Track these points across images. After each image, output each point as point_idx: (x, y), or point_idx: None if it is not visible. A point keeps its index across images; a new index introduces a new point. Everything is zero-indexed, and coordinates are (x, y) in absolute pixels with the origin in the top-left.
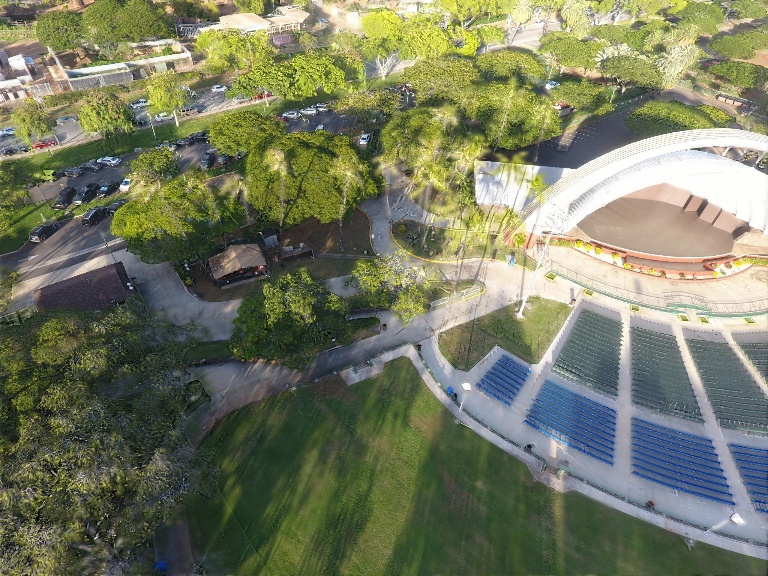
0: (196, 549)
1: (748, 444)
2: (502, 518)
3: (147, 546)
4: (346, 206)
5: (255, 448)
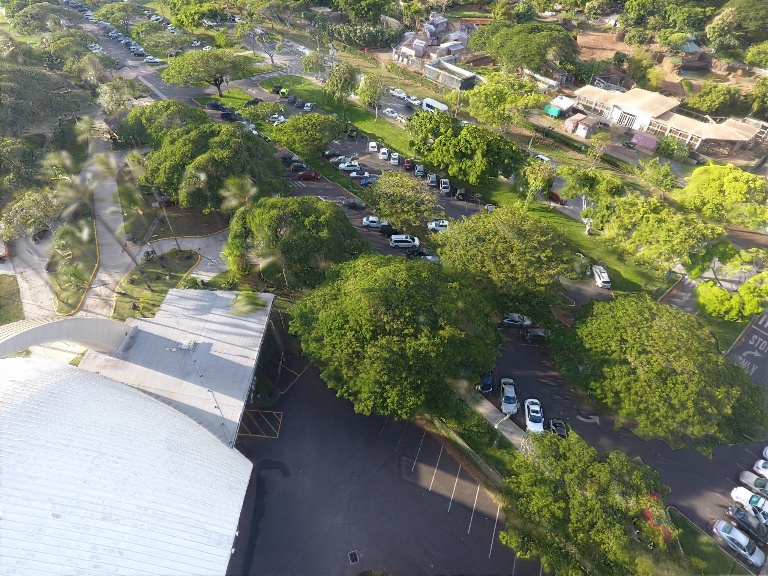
0: None
1: None
2: None
3: None
4: (146, 182)
5: None
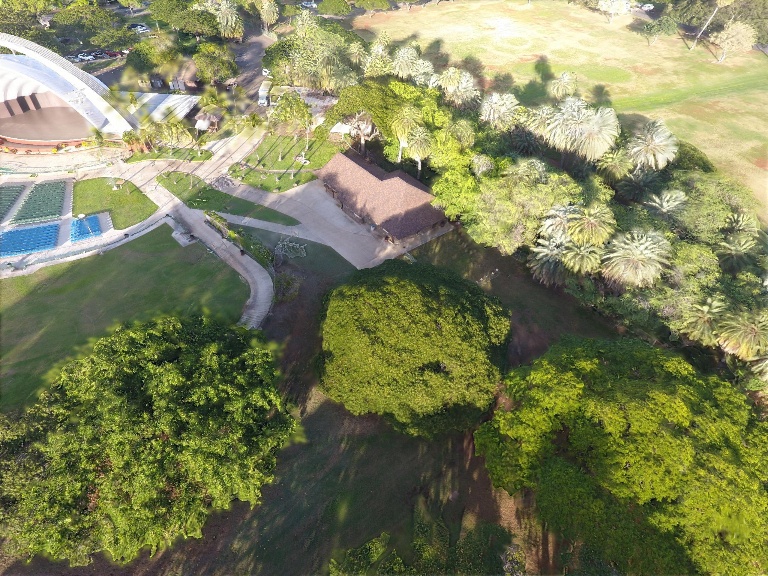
0: None
1: None
2: None
3: None
4: None
5: None
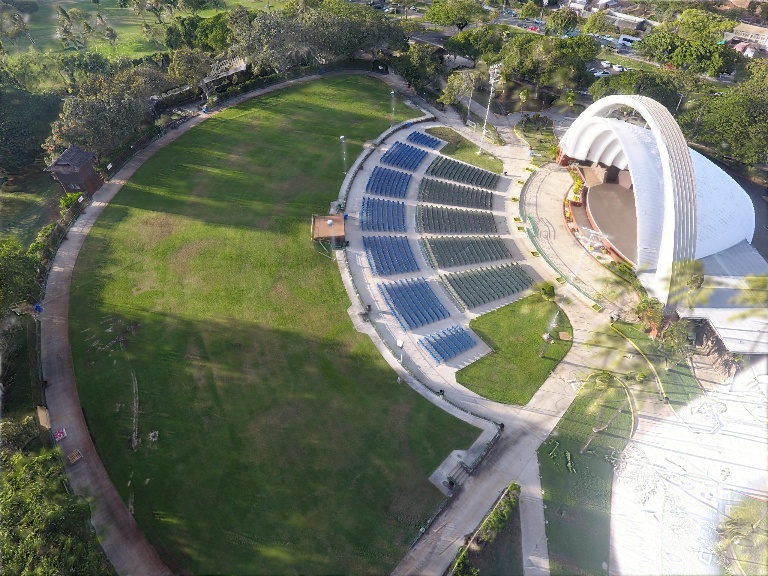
0: (329, 77)
1: (407, 212)
2: (348, 130)
3: (328, 69)
4: (514, 71)
5: (365, 84)
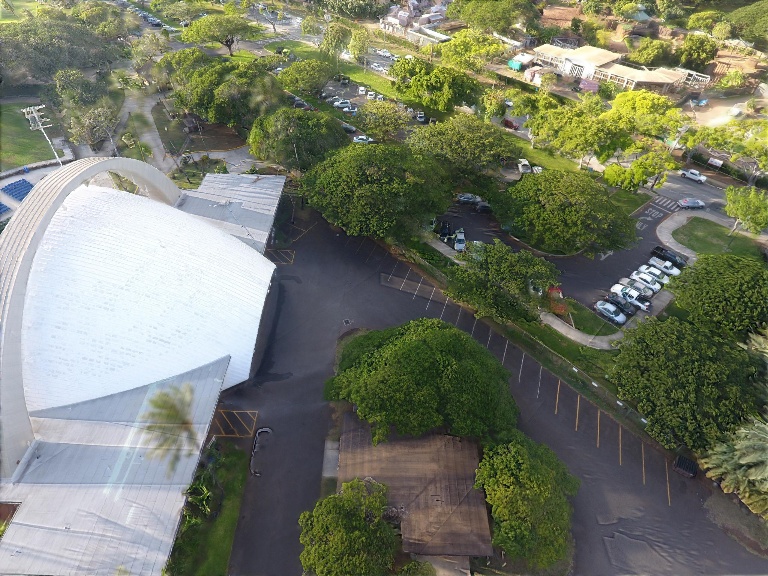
0: None
1: None
2: None
3: None
4: None
5: None
